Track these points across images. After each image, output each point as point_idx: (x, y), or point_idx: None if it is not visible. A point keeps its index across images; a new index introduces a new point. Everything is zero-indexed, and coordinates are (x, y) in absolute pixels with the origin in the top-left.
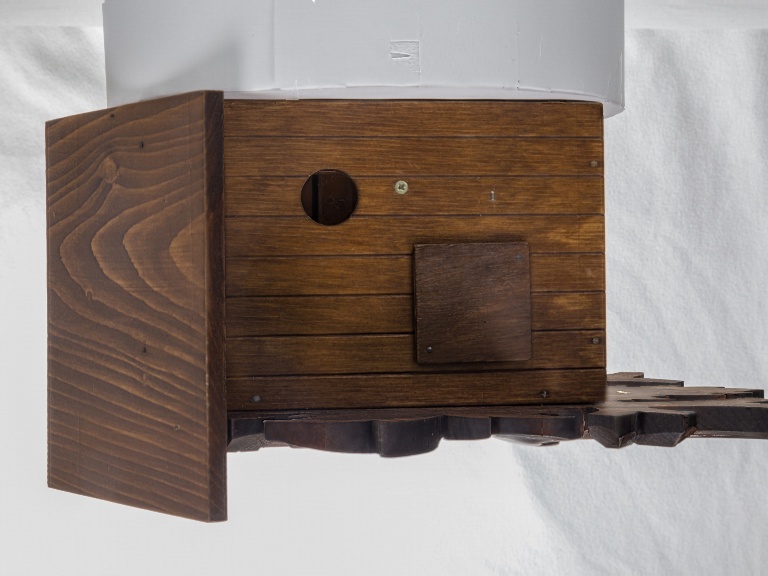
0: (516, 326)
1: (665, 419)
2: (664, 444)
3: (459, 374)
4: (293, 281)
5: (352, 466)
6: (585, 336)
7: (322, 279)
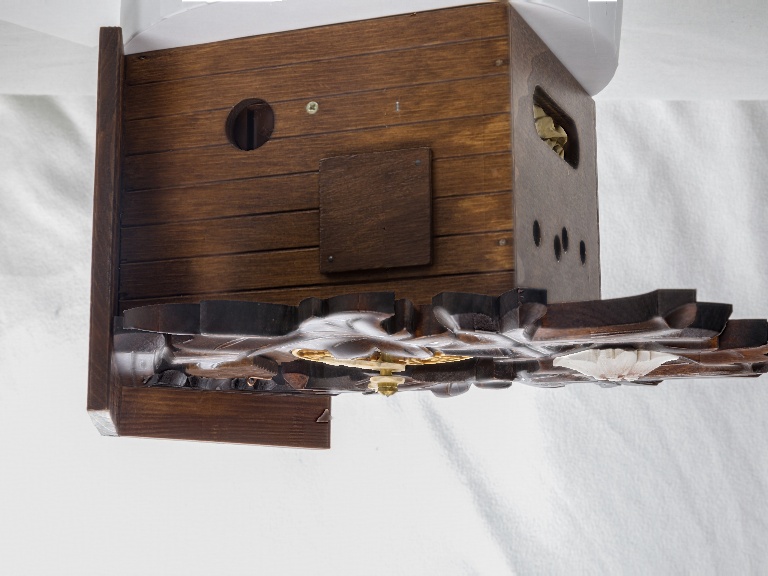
0: (415, 231)
1: (508, 297)
2: (514, 326)
3: (365, 284)
4: (217, 204)
5: (407, 434)
6: (491, 238)
7: (241, 200)
